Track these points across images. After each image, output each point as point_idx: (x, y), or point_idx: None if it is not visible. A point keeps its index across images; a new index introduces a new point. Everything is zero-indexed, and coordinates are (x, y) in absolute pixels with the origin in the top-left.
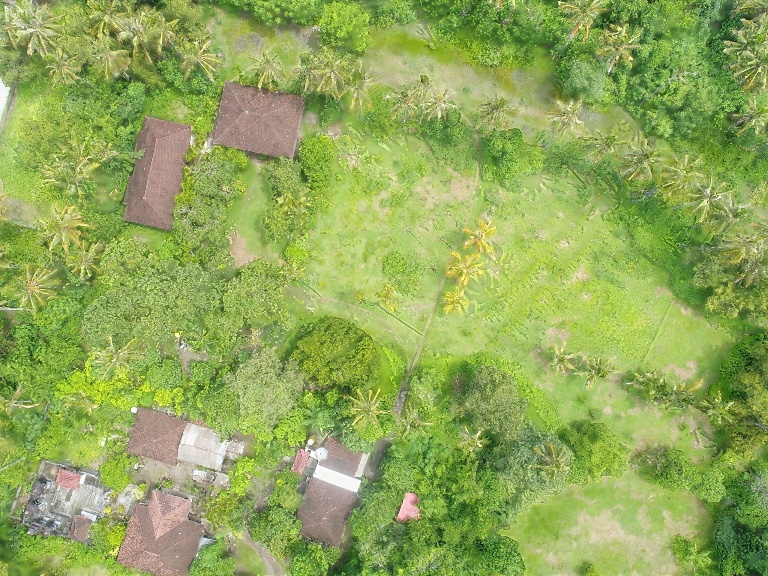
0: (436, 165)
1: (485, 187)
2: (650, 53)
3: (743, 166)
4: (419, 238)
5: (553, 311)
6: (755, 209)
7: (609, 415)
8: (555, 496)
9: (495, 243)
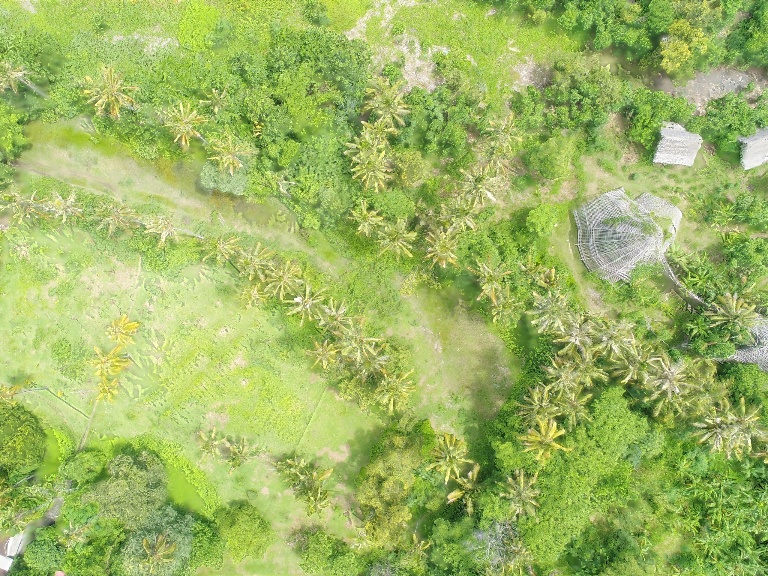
0: (100, 256)
1: (147, 277)
2: (280, 153)
3: (392, 257)
4: (86, 325)
5: (212, 396)
6: (407, 298)
7: (266, 495)
8: (218, 570)
9: (157, 331)
